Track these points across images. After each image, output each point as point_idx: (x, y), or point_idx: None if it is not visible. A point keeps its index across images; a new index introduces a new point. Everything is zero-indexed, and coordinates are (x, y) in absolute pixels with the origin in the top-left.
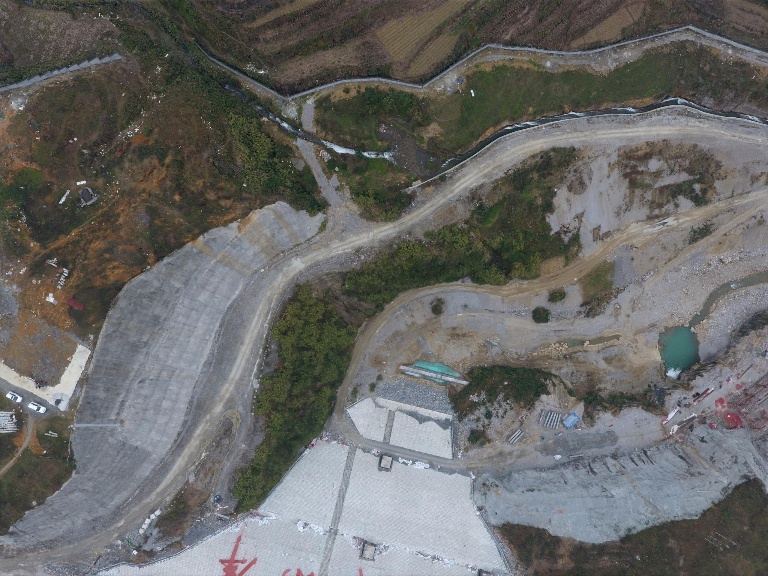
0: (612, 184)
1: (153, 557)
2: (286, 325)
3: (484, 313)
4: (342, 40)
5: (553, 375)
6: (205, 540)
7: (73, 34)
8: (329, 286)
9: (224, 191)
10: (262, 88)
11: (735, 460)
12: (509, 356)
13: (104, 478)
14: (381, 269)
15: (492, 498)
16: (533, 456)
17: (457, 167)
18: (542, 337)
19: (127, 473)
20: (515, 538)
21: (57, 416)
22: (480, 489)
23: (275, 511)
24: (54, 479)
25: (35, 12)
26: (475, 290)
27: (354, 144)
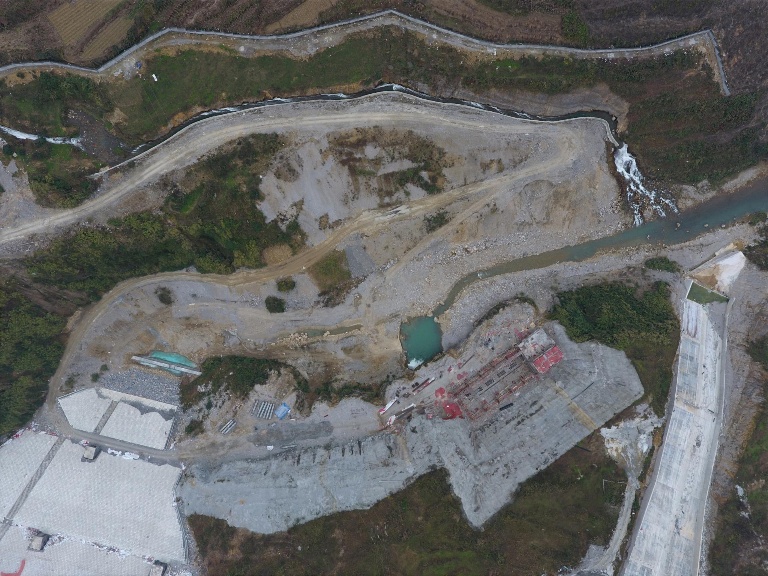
0: (330, 171)
1: None
2: None
3: (217, 303)
4: (9, 24)
5: (285, 365)
6: None
7: None
8: (12, 274)
9: None
10: None
11: (429, 450)
12: (246, 346)
13: None
14: (67, 256)
15: (187, 489)
16: (246, 447)
17: (148, 153)
18: (279, 327)
19: None
20: (197, 529)
21: None
22: (182, 480)
23: None
24: None
25: None
26: (200, 279)
27: (34, 130)
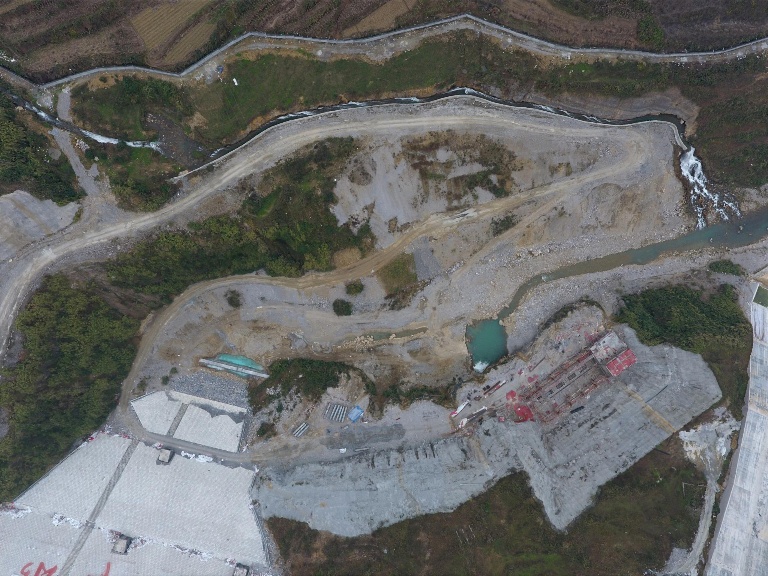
0: (401, 175)
1: None
2: (32, 316)
3: (284, 306)
4: (94, 28)
5: (353, 368)
6: None
7: None
8: (93, 277)
9: None
10: (16, 77)
11: (507, 453)
12: (313, 349)
13: None
14: (147, 260)
15: (264, 491)
16: (318, 449)
17: (226, 157)
18: (346, 330)
19: None
20: (277, 532)
21: None
22: (257, 483)
23: (32, 504)
24: None
25: None
26: (270, 282)
27: (115, 133)
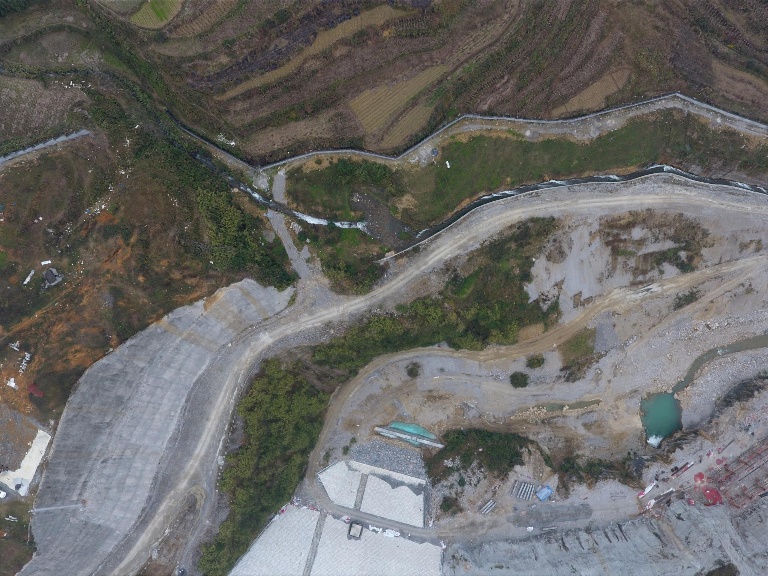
0: (594, 252)
1: None
2: (252, 401)
3: (461, 376)
4: (314, 112)
5: (530, 441)
6: None
7: (44, 103)
8: (299, 357)
9: (190, 270)
10: (233, 159)
11: (710, 543)
12: (486, 419)
13: (66, 557)
14: None
15: (460, 572)
16: (505, 527)
17: (432, 238)
18: (520, 401)
19: (90, 550)
20: None
21: (17, 501)
22: (449, 561)
23: None
24: (14, 561)
25: (7, 80)
26: (451, 355)
27: (326, 215)
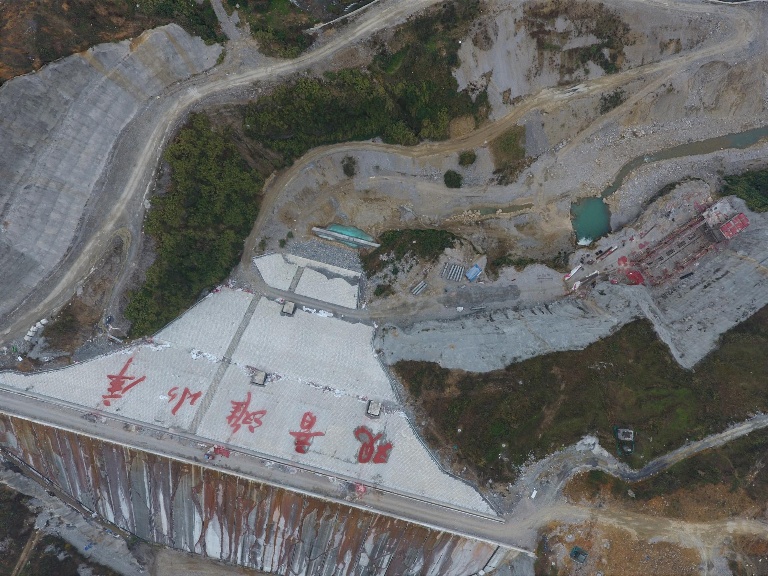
0: (520, 43)
1: (39, 367)
2: (180, 150)
3: (396, 176)
4: None
5: (463, 238)
6: (95, 359)
7: None
8: (229, 123)
9: (115, 8)
10: None
11: (628, 304)
12: (422, 221)
13: None
14: (282, 109)
15: (389, 339)
16: (436, 308)
17: (359, 12)
18: (454, 203)
19: (13, 280)
20: (407, 372)
21: None
22: (380, 334)
23: (170, 340)
24: None
25: None
26: (386, 150)
27: None
